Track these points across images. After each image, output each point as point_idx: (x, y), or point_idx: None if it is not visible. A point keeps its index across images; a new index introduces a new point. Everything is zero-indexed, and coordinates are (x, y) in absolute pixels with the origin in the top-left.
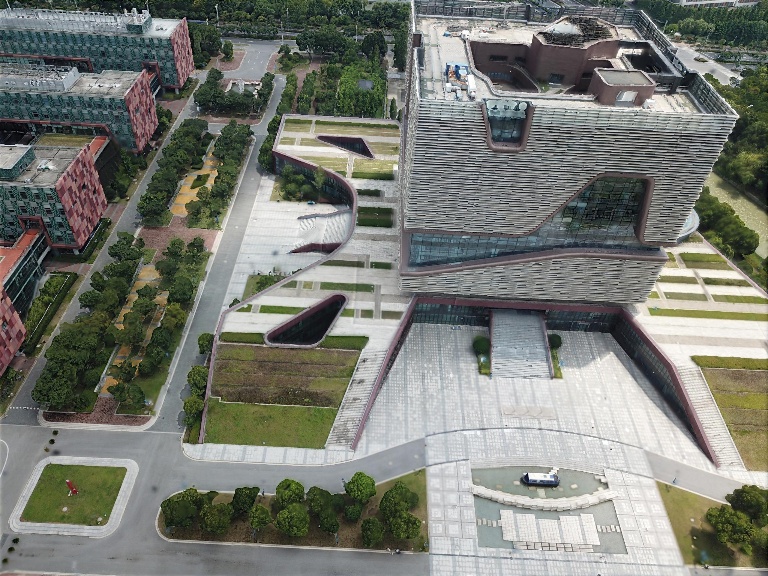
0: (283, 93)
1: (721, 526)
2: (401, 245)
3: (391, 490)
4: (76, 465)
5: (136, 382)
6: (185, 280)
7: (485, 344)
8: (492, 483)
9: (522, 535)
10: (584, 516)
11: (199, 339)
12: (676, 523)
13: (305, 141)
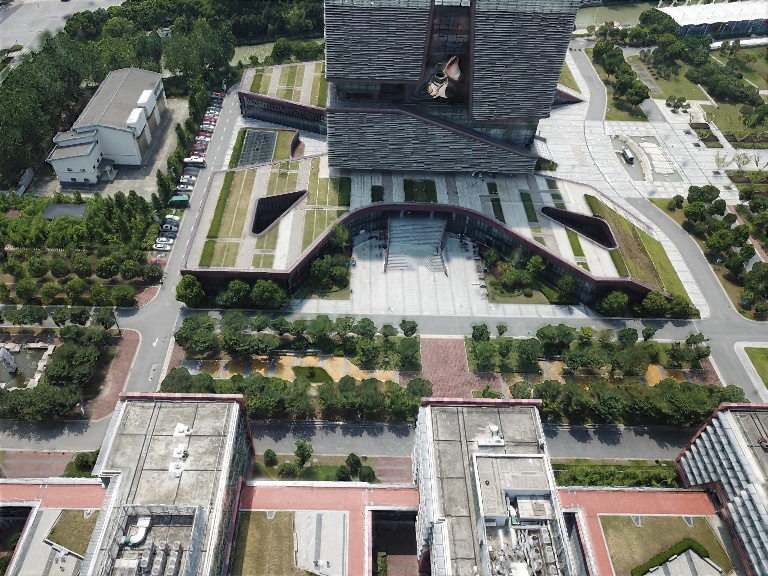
0: (77, 290)
1: (646, 94)
2: (511, 150)
3: (694, 194)
4: (763, 382)
5: (664, 363)
6: (549, 327)
7: (539, 158)
8: (639, 175)
9: (667, 167)
10: (642, 145)
11: (622, 302)
12: (628, 119)
13: (264, 245)
